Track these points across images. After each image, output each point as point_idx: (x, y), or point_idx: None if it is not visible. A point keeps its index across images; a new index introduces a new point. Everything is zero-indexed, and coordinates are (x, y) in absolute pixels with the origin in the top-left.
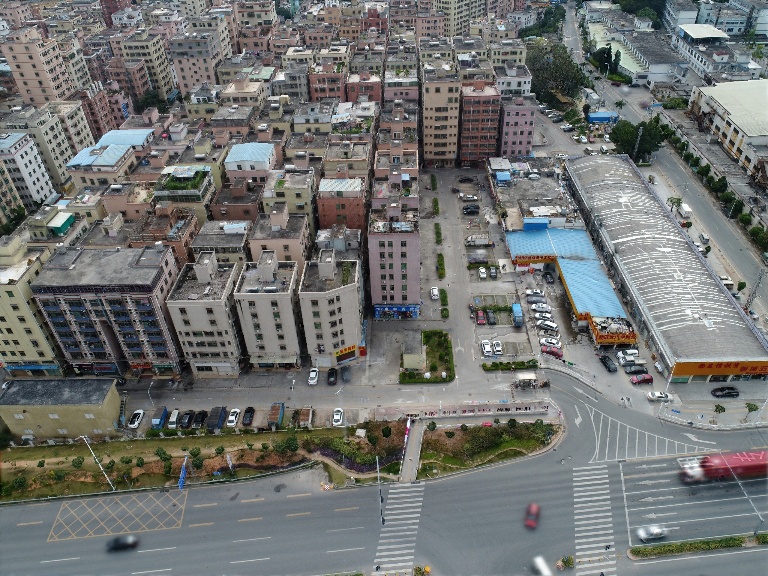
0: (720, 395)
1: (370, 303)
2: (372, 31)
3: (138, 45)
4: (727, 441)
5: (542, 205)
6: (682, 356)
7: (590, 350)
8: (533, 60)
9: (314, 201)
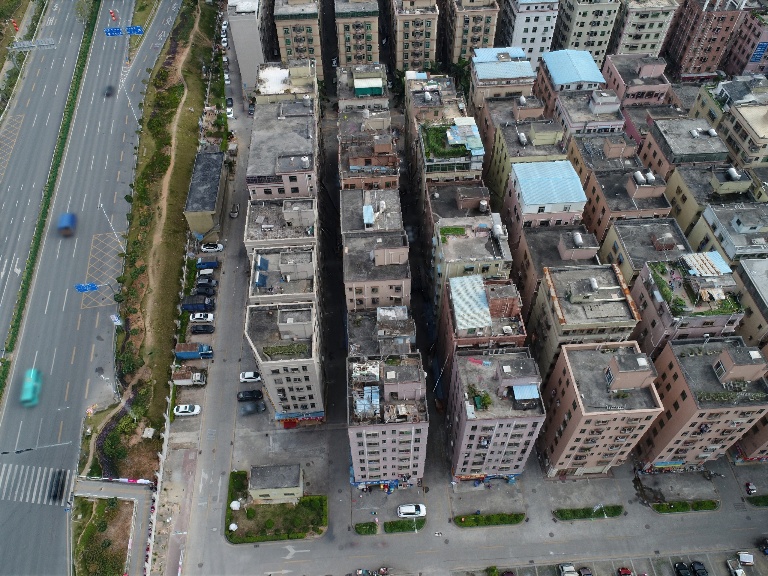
0: None
1: None
2: None
3: None
4: None
5: None
6: None
7: None
8: None
9: None
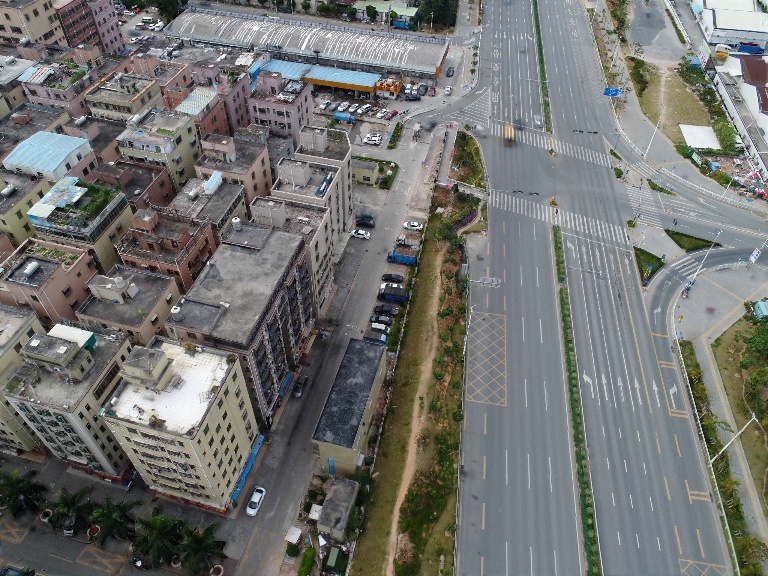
0: (452, 74)
1: None
2: None
3: None
4: (485, 84)
5: (236, 58)
6: (431, 66)
7: (396, 102)
8: None
9: None
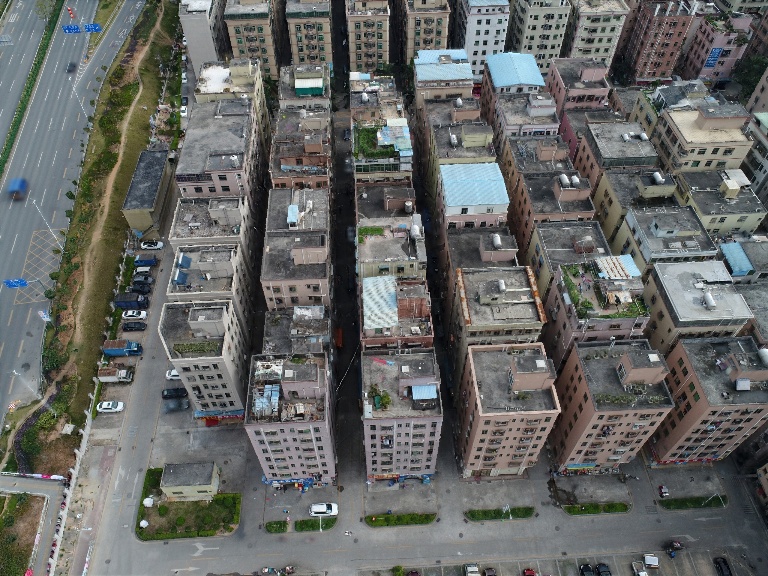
0: None
1: None
2: None
3: None
4: None
5: None
6: None
7: None
8: None
9: None
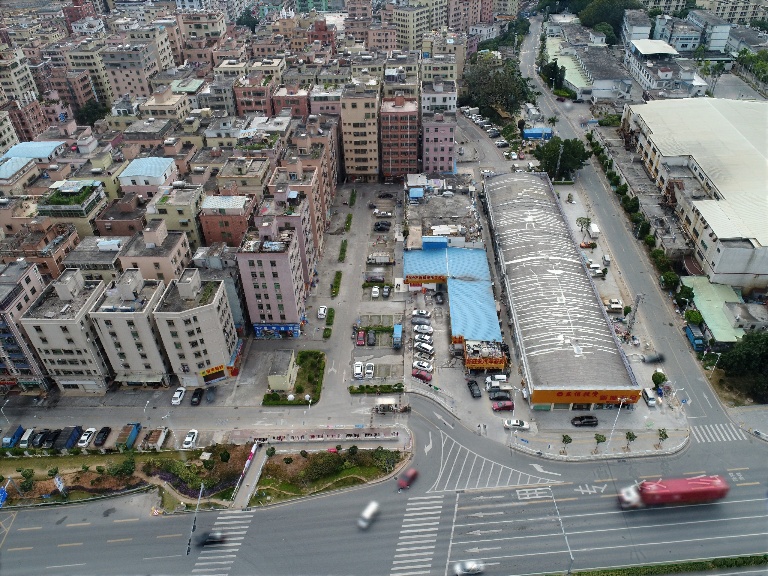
0: (578, 424)
1: (250, 322)
2: (316, 44)
3: (83, 55)
4: (572, 473)
5: (445, 224)
6: (543, 383)
7: (461, 374)
8: (478, 74)
9: (199, 218)
